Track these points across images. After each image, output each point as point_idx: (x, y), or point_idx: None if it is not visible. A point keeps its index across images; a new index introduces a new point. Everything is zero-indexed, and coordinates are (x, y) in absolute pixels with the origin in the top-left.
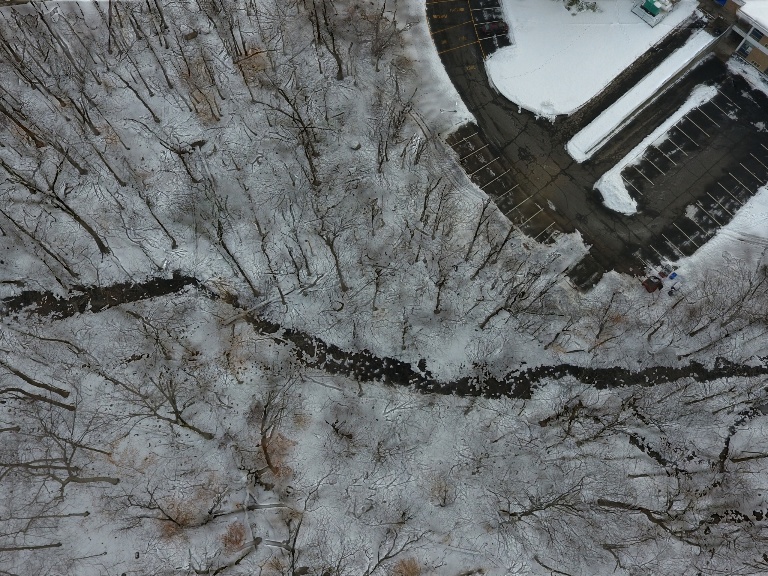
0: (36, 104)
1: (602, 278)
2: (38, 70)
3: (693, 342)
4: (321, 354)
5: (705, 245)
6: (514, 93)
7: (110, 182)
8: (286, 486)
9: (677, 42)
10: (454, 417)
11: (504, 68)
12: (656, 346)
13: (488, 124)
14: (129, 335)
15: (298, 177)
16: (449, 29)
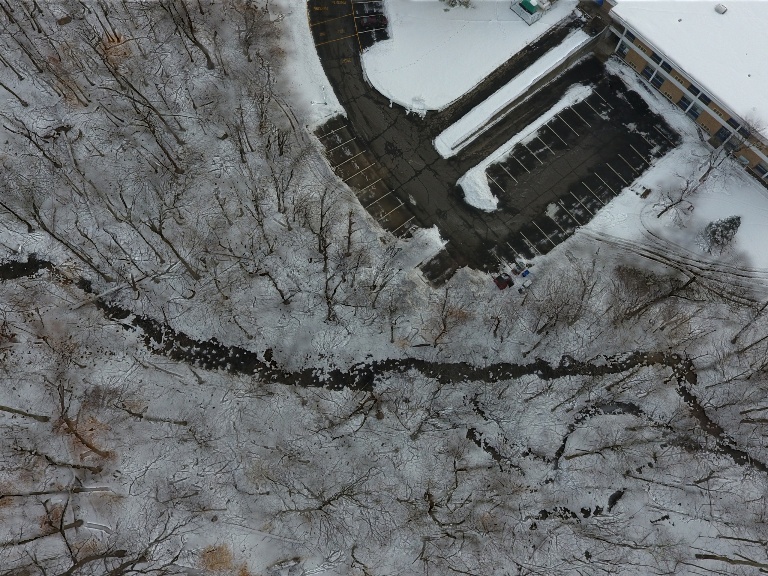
0: None
1: (455, 274)
2: None
3: (539, 340)
4: (169, 341)
5: (562, 244)
6: (387, 87)
7: None
8: (114, 470)
9: (554, 41)
10: (292, 407)
11: (379, 62)
12: (502, 343)
13: (358, 117)
14: None
15: (160, 165)
16: (329, 21)
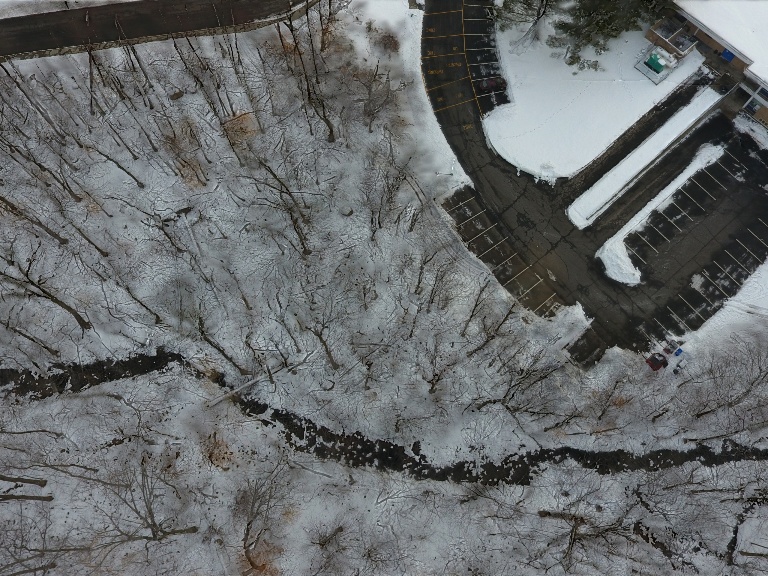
0: (15, 169)
1: (604, 354)
2: (17, 134)
3: (699, 423)
4: (311, 437)
5: (712, 318)
6: (513, 154)
7: (91, 252)
8: None
9: (682, 100)
10: (449, 507)
11: (502, 127)
12: (661, 428)
13: (486, 188)
14: (110, 418)
15: (287, 246)
16: (445, 85)
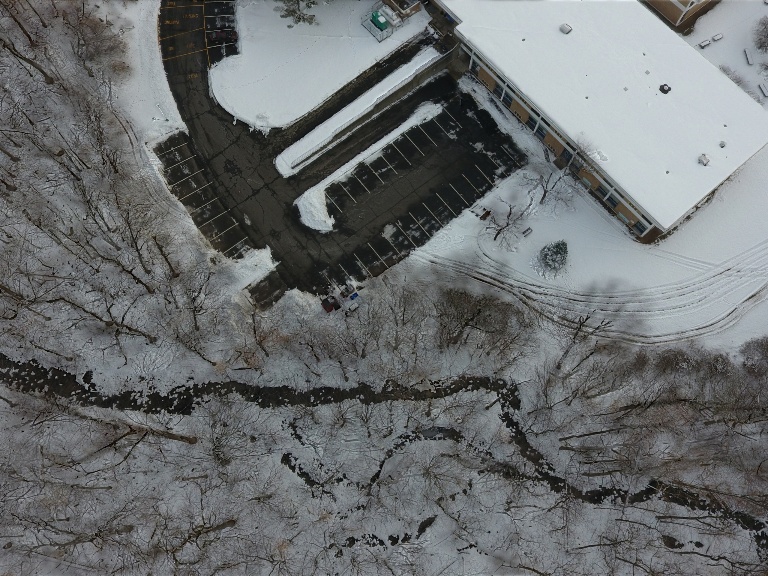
0: None
1: (283, 296)
2: None
3: (363, 364)
4: None
5: (394, 266)
6: (231, 104)
7: None
8: None
9: (404, 58)
10: (104, 431)
11: (226, 78)
12: (324, 366)
13: (199, 134)
14: None
15: None
16: (179, 35)
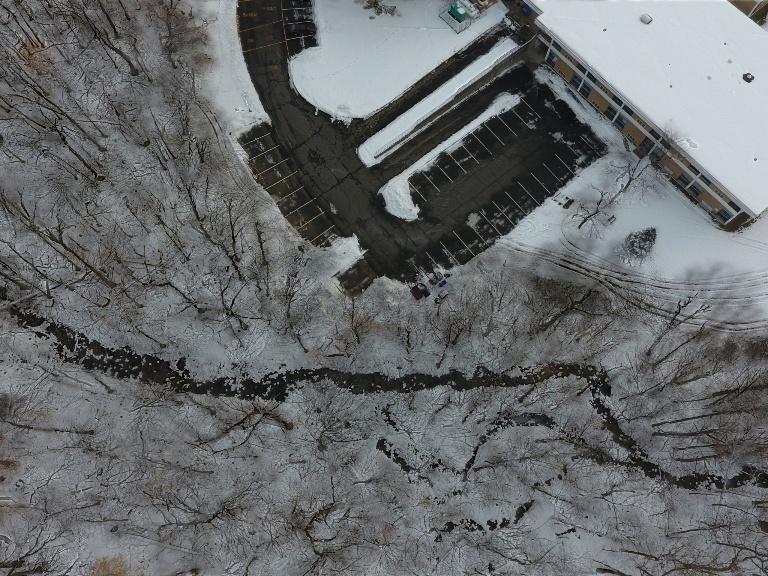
0: None
1: (372, 283)
2: None
3: (454, 350)
4: (82, 349)
5: (481, 254)
6: (313, 95)
7: None
8: (17, 479)
9: (482, 49)
10: (201, 417)
11: (306, 69)
12: (416, 353)
13: (282, 125)
14: None
15: (80, 171)
16: (257, 28)
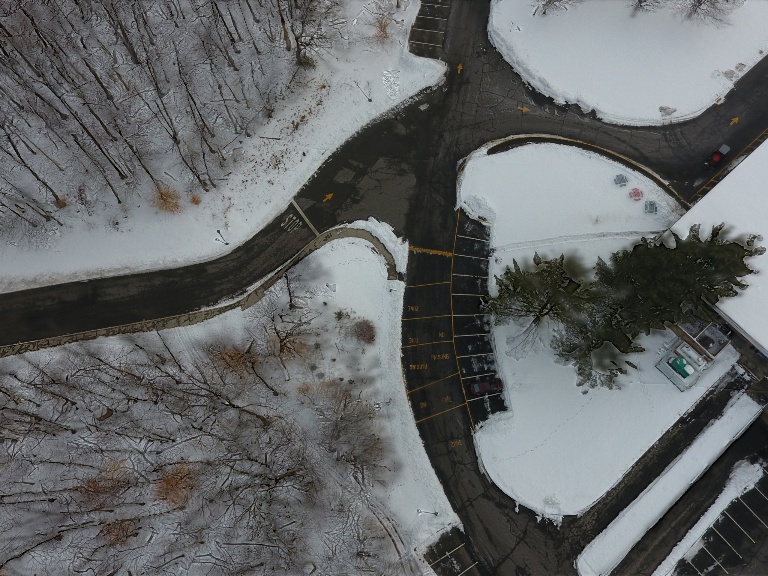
0: None
1: None
2: None
3: None
4: None
5: None
6: (510, 483)
7: None
8: None
9: (713, 410)
10: None
11: (498, 445)
12: None
13: (477, 530)
14: None
15: None
16: (430, 386)
